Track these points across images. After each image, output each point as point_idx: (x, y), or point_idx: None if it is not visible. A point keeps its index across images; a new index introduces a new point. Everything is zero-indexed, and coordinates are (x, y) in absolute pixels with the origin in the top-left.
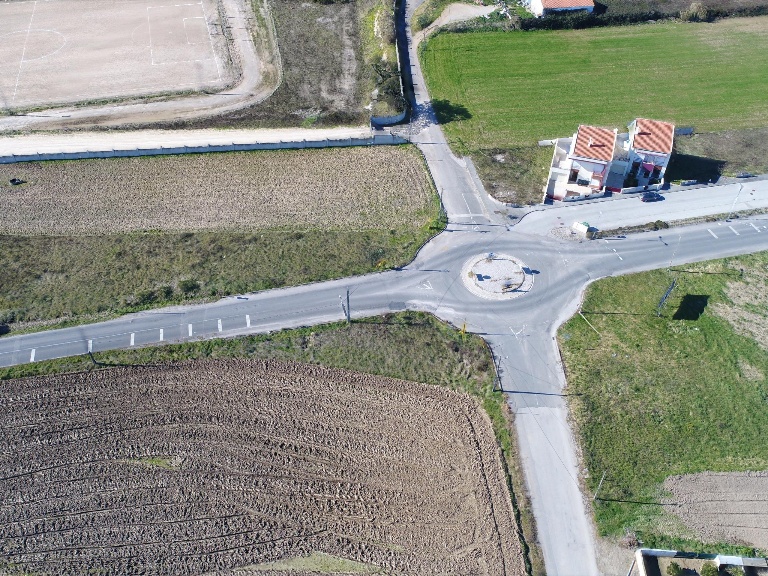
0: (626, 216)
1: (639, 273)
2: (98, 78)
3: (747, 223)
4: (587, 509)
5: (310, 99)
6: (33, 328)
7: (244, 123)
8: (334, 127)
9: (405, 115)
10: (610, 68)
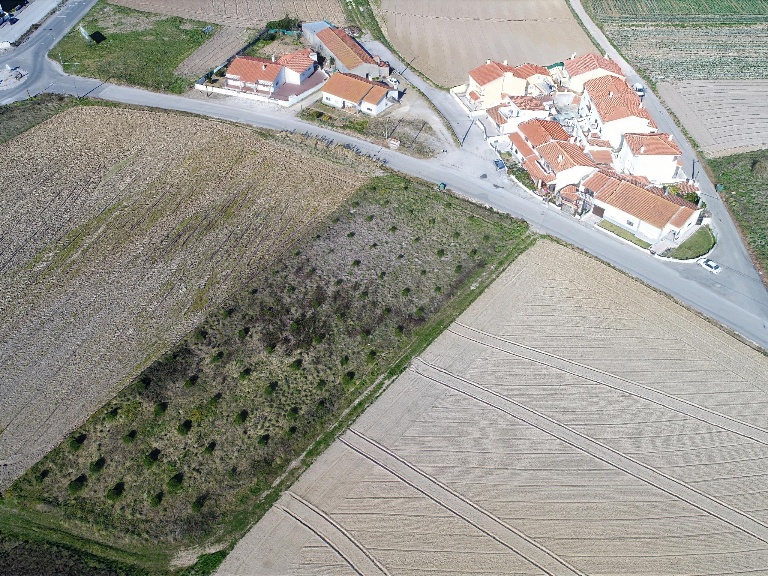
0: (15, 32)
1: (60, 42)
2: None
3: (68, 6)
4: (166, 94)
5: None
6: None
7: None
8: None
9: None
10: None
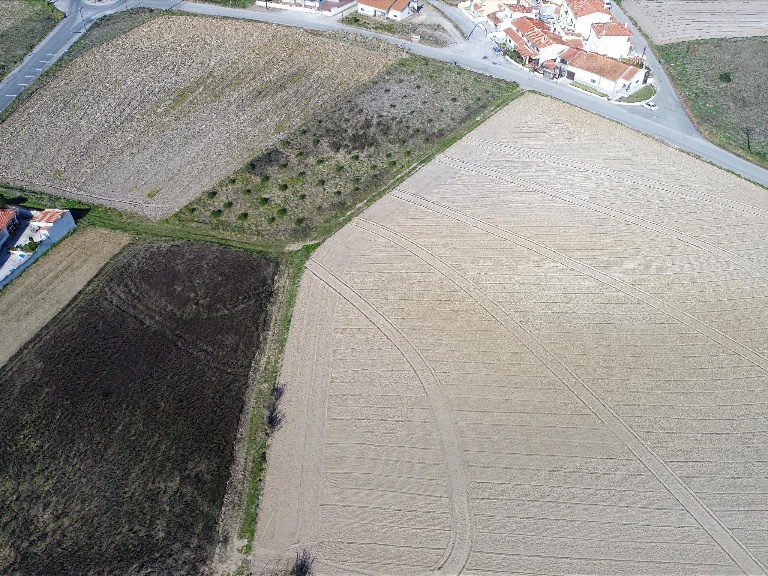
0: None
1: None
2: None
3: None
4: (233, 8)
5: None
6: None
7: None
8: None
9: None
10: None
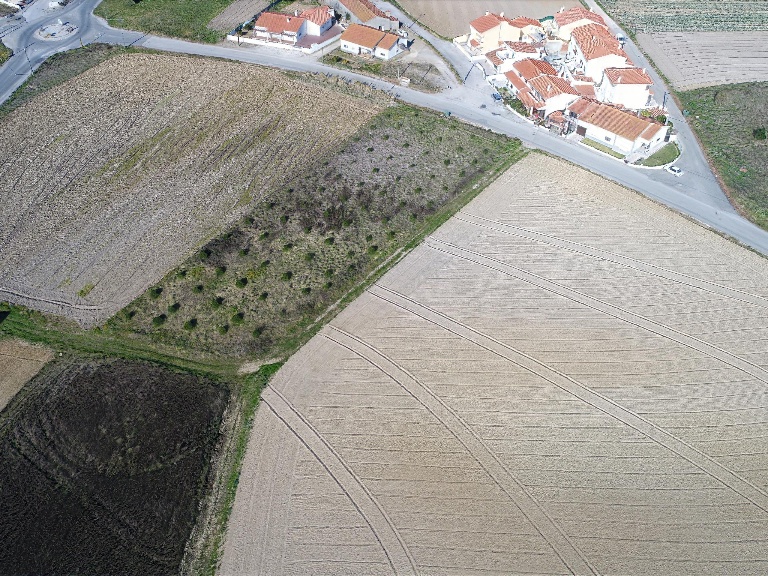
0: None
1: (102, 2)
2: None
3: None
4: None
5: None
6: None
7: None
8: None
9: None
10: None
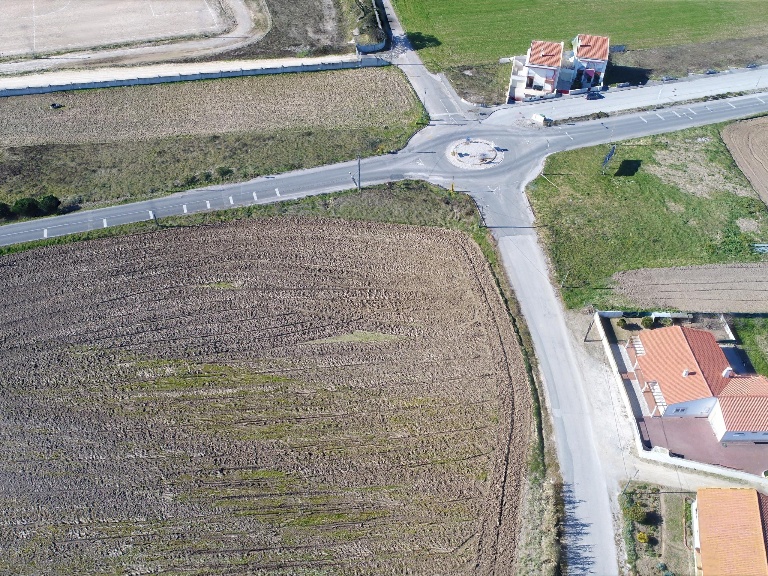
0: (574, 110)
1: (587, 147)
2: (107, 28)
3: (670, 111)
4: (557, 294)
5: (299, 38)
6: (100, 205)
7: (245, 58)
8: (325, 56)
9: (385, 44)
10: (554, 5)
